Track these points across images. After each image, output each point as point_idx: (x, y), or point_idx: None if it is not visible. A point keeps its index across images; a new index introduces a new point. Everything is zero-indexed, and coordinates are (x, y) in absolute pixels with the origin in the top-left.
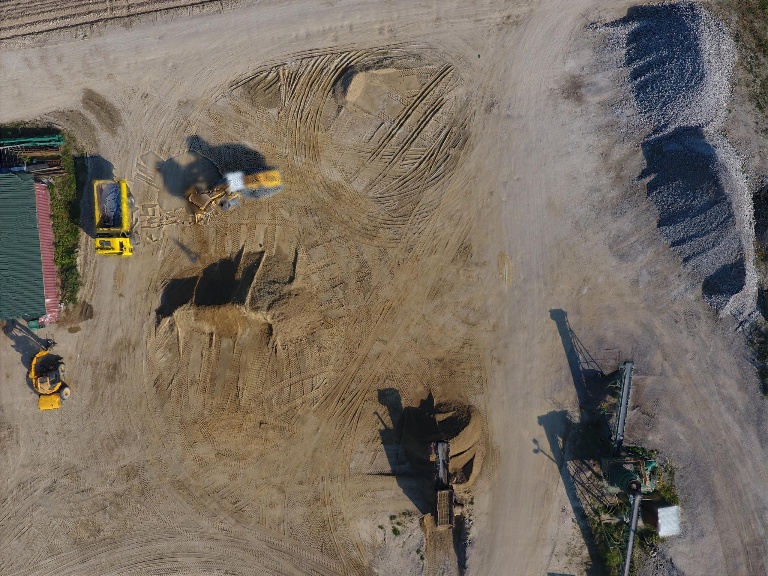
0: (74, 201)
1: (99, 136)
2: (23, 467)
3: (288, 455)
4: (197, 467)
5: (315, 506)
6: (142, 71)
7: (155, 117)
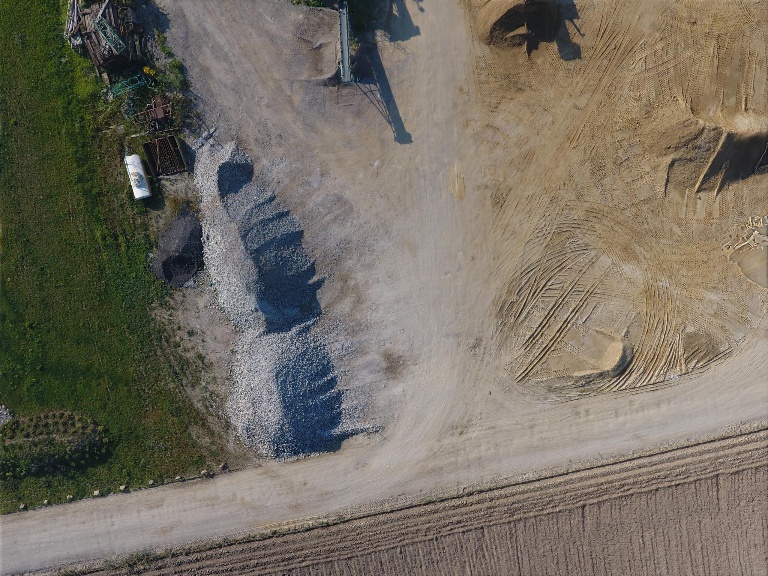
0: None
1: None
2: None
3: None
4: None
5: None
6: None
7: None
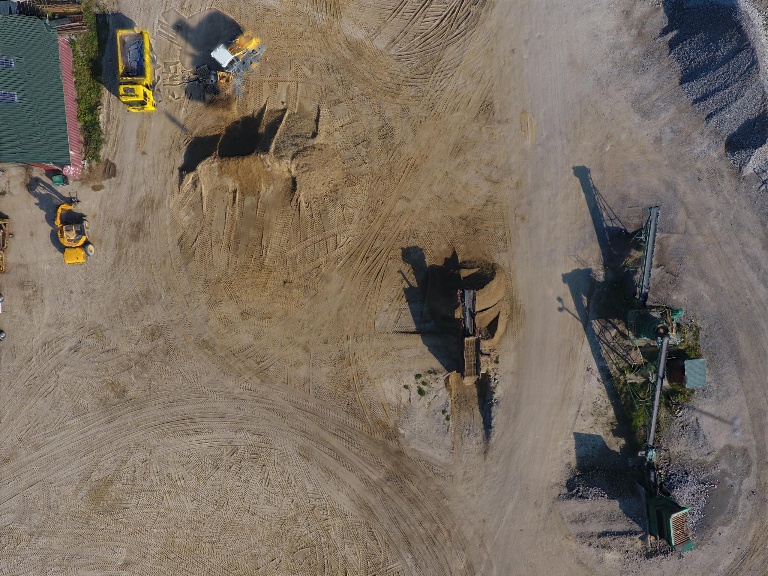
0: (96, 58)
1: None
2: (48, 326)
3: (313, 314)
4: (222, 326)
5: (340, 365)
6: None
7: None
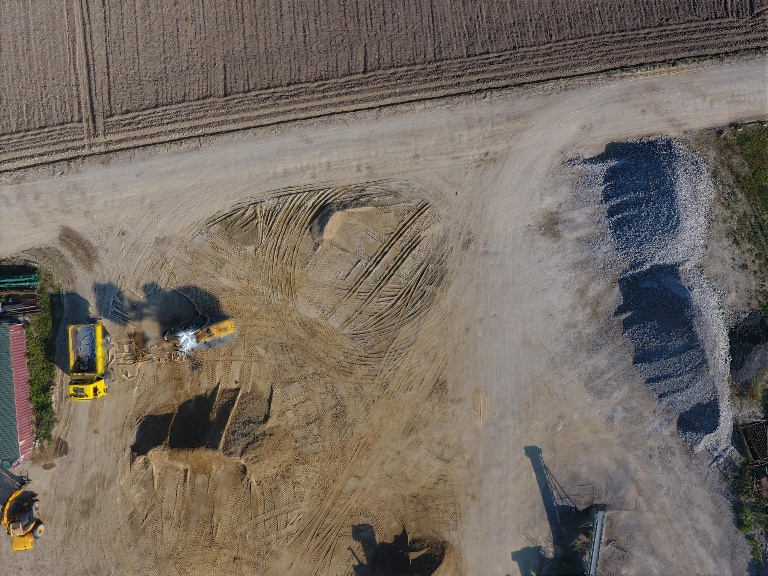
0: (50, 339)
1: (76, 273)
2: None
3: None
4: None
5: None
6: (119, 209)
7: (132, 254)
